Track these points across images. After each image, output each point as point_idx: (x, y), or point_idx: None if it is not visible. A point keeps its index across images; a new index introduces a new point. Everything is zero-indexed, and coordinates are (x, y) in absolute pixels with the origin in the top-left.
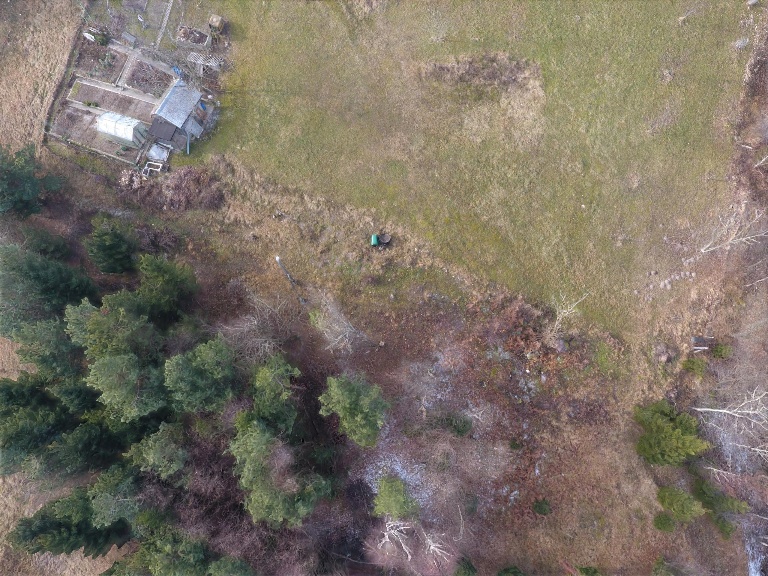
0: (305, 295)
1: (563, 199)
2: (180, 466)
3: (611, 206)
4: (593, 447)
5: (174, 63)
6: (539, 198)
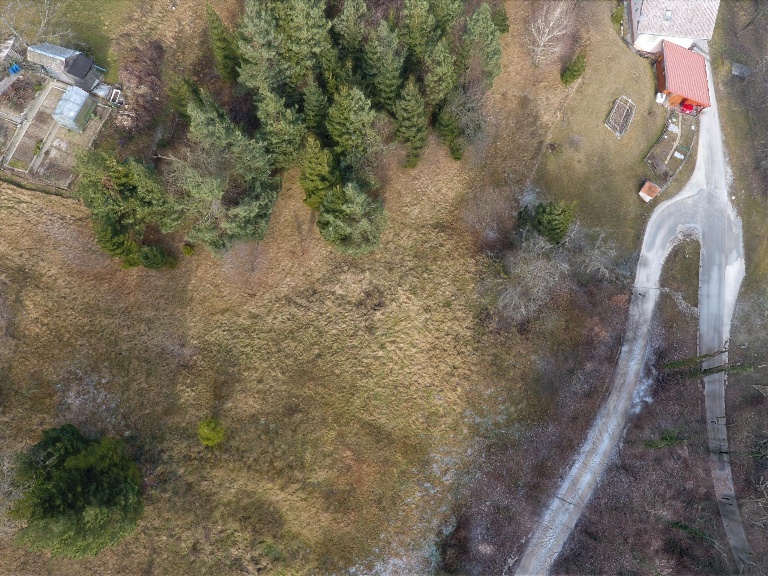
0: None
1: None
2: None
3: None
4: None
5: (4, 75)
6: None
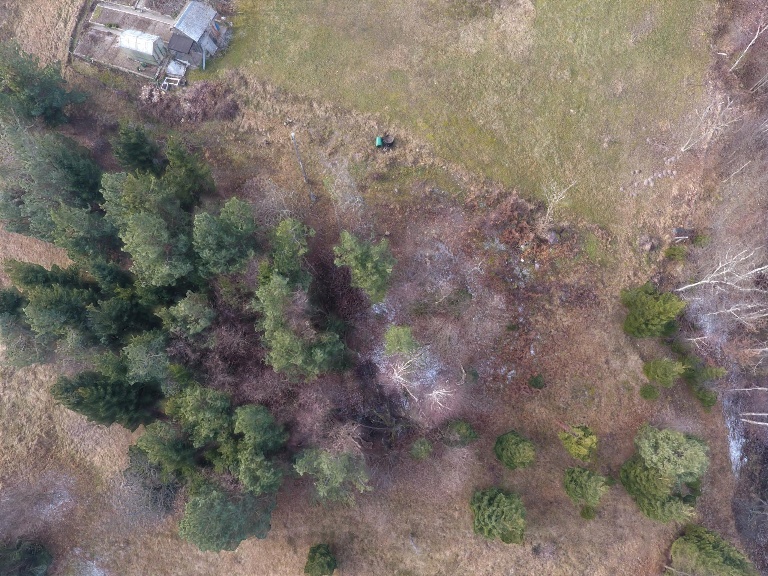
0: (315, 192)
1: (553, 105)
2: (207, 324)
3: (597, 110)
4: (584, 328)
5: None
6: (531, 104)
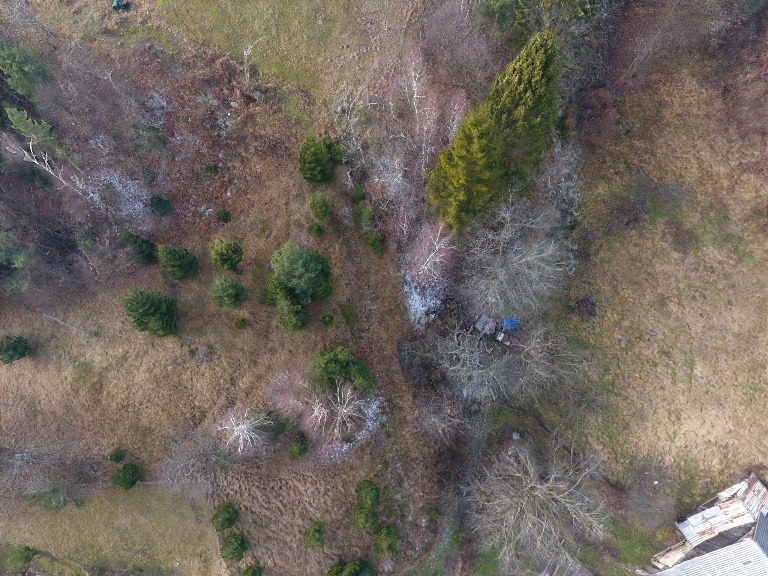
0: (56, 44)
1: None
2: None
3: None
4: (274, 176)
5: None
6: None
